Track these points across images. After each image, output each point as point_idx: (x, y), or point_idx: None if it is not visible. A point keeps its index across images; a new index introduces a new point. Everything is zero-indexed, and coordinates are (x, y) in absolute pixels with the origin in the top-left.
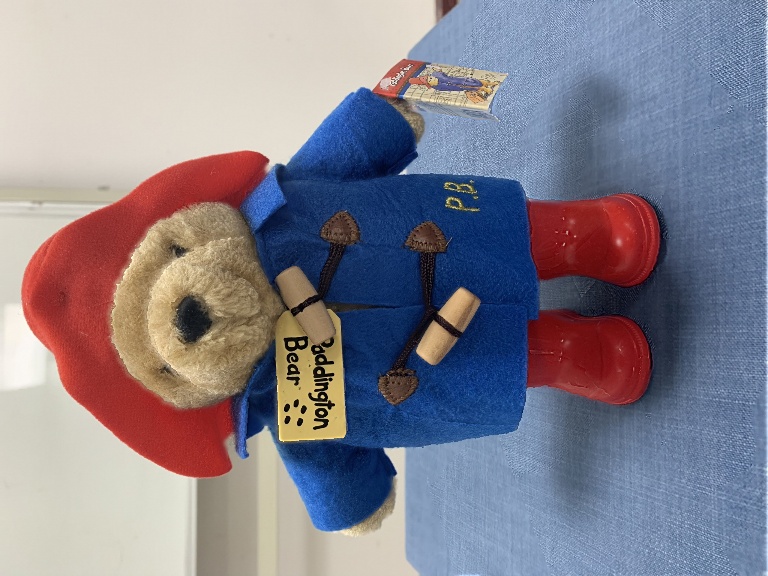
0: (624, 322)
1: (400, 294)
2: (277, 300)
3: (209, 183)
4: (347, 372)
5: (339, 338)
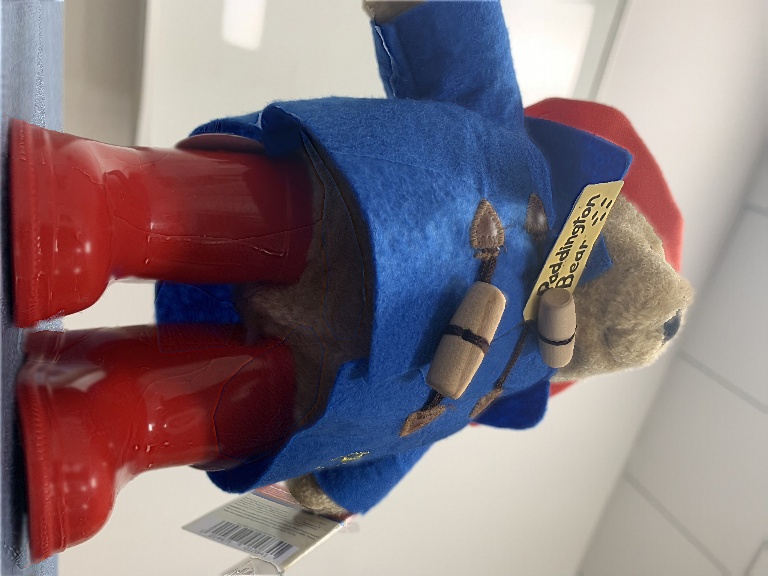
0: None
1: None
2: (575, 331)
3: None
4: (527, 248)
5: (534, 293)
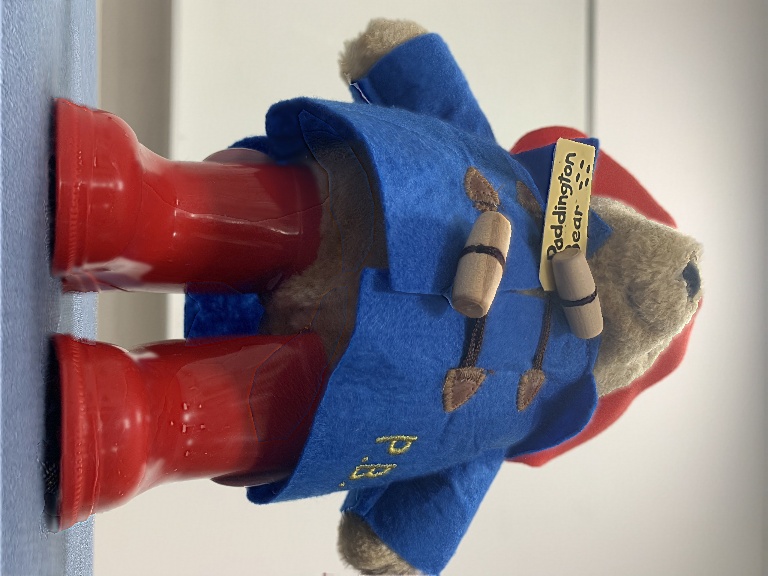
0: (73, 261)
1: (505, 308)
2: (599, 300)
3: None
4: (524, 215)
5: (543, 256)
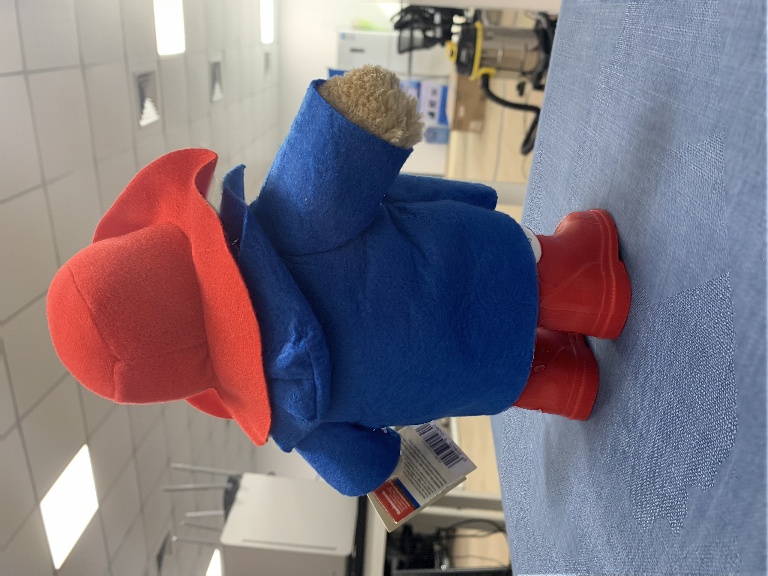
0: None
1: None
2: None
3: None
4: None
5: None
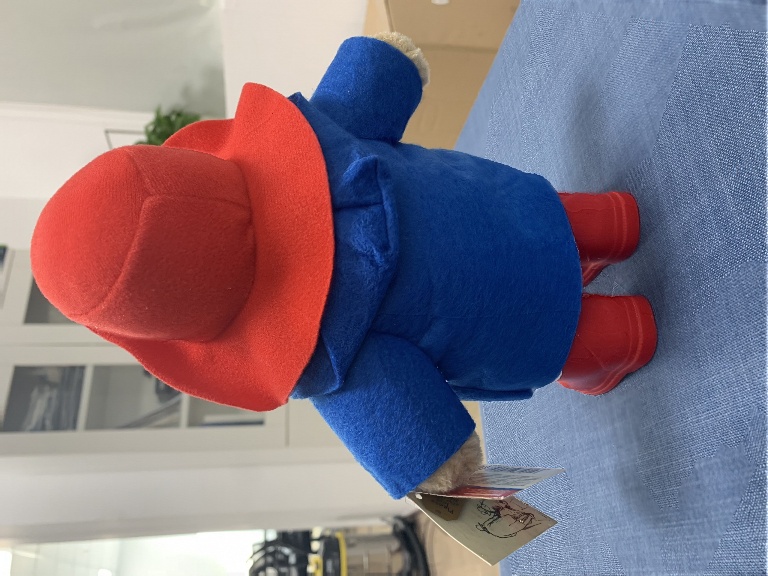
0: None
1: None
2: None
3: (217, 374)
4: None
5: None
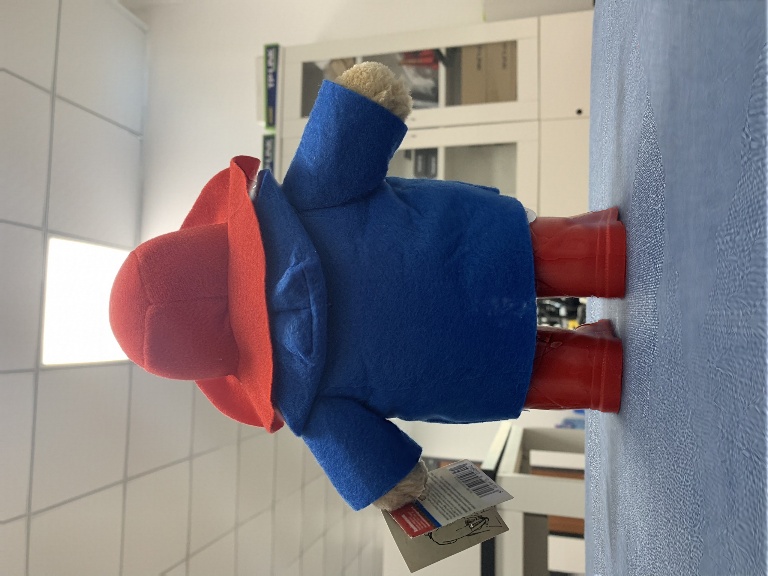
0: None
1: None
2: None
3: None
4: None
5: None
